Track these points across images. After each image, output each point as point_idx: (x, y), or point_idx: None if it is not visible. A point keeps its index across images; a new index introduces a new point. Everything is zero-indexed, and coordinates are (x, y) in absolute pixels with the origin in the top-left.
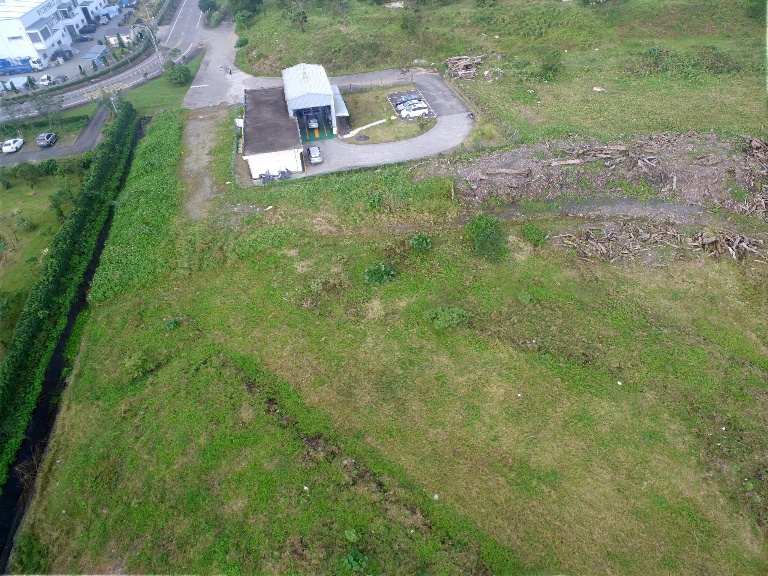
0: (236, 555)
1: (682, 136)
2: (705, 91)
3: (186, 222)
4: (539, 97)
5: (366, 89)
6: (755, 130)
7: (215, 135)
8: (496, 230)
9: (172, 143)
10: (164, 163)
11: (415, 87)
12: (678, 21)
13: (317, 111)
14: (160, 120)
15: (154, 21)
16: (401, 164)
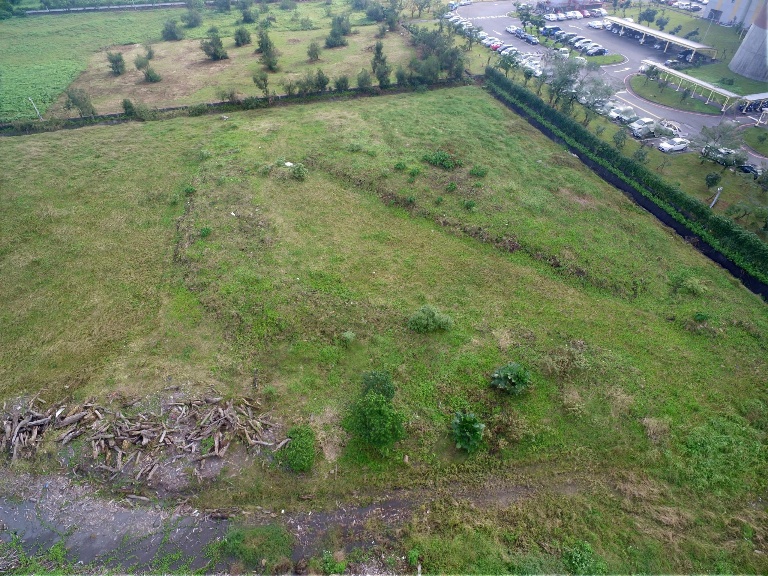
0: None
1: None
2: None
3: None
4: None
5: None
6: None
7: None
8: None
9: None
10: None
11: None
12: None
13: None
14: None
15: None
16: None
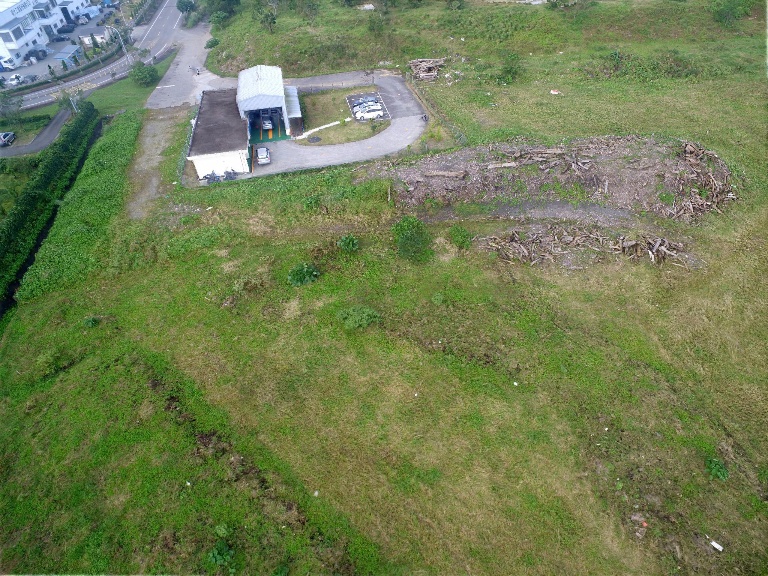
0: (107, 548)
1: (621, 140)
2: (659, 95)
3: (125, 222)
4: (495, 100)
5: (327, 91)
6: (700, 134)
7: (171, 135)
8: (419, 232)
9: (126, 143)
10: (114, 163)
11: (376, 89)
12: (644, 25)
13: (275, 112)
14: (120, 120)
15: (132, 21)
16: (347, 166)
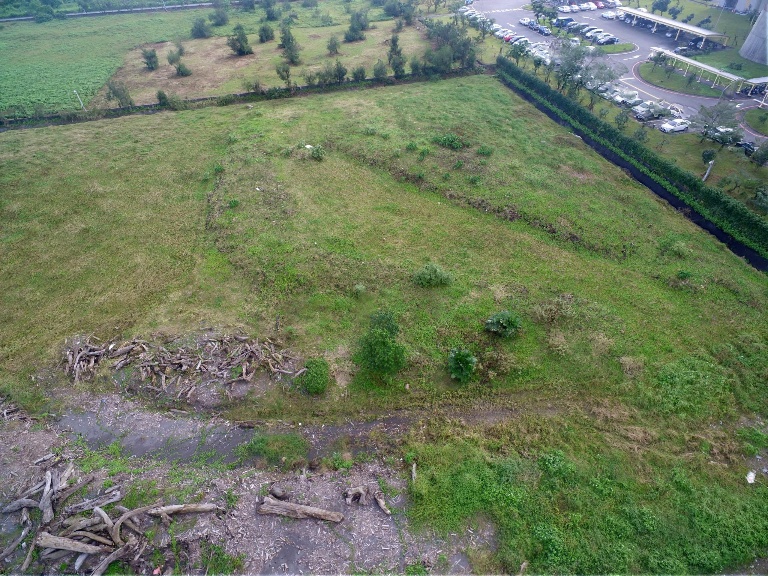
0: None
1: None
2: None
3: None
4: None
5: None
6: None
7: None
8: None
9: None
10: None
11: None
12: None
13: None
14: None
15: None
16: None
